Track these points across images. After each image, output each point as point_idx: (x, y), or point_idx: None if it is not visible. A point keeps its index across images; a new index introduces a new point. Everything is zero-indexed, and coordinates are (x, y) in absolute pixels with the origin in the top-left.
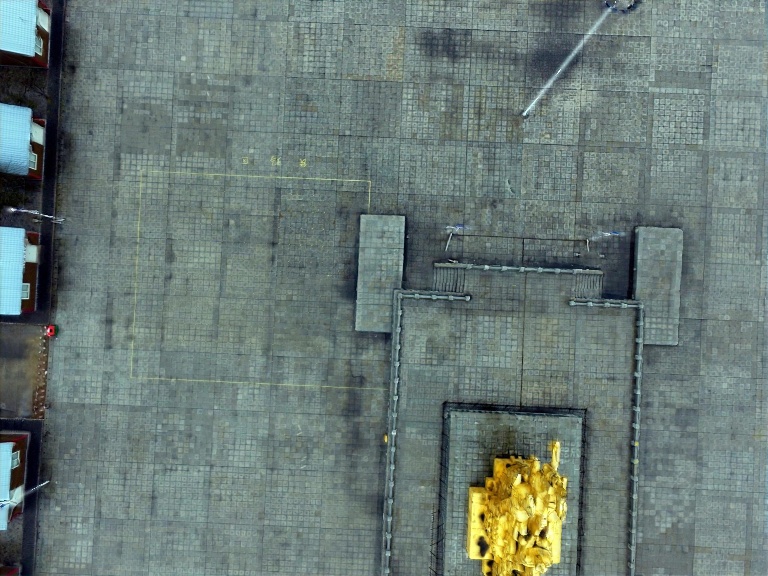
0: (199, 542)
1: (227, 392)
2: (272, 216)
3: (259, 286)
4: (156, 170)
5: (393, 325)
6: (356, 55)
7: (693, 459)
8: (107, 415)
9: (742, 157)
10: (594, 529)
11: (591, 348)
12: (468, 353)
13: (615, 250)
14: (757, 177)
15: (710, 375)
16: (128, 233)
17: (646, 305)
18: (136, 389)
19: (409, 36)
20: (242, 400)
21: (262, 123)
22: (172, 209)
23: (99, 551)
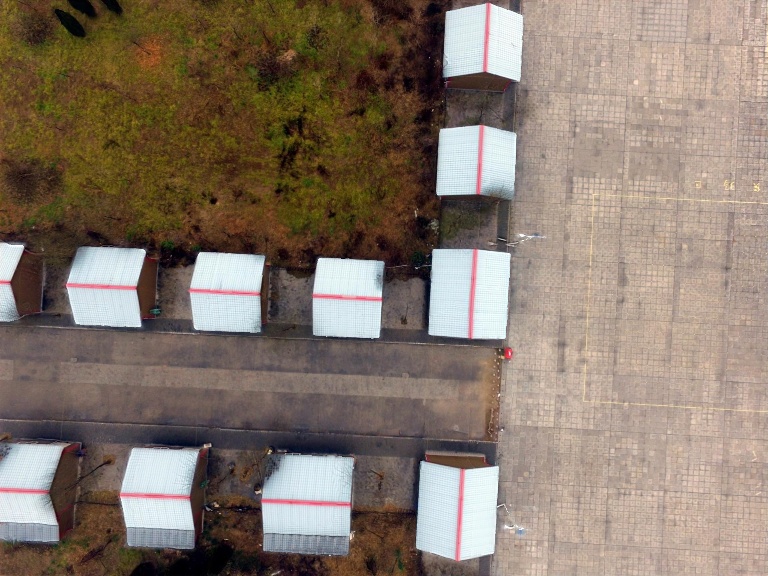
0: (654, 567)
1: (680, 417)
2: (725, 241)
3: (712, 311)
4: (608, 194)
5: None
6: None
7: None
8: (560, 438)
9: None
10: None
11: None
12: None
13: None
14: None
15: None
16: (581, 257)
17: None
18: (589, 413)
19: None
20: (696, 425)
21: (715, 147)
22: (624, 233)
23: (554, 575)
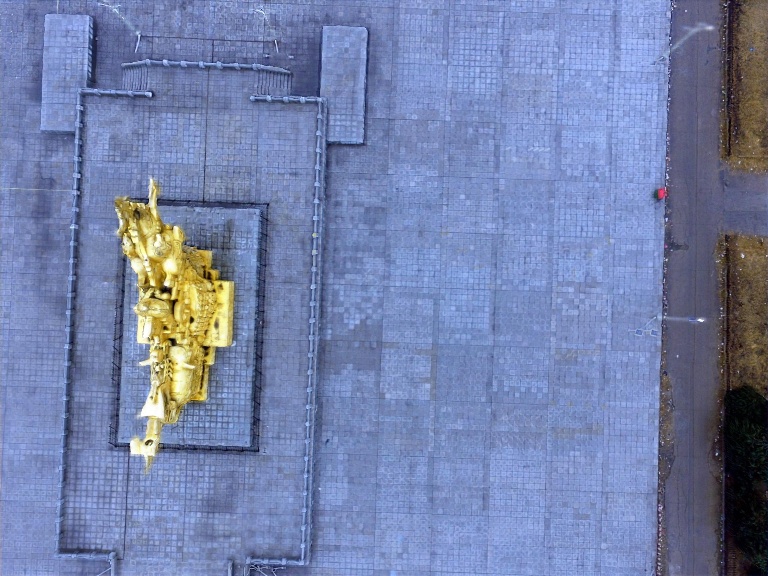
0: None
1: None
2: None
3: None
4: None
5: None
6: None
7: (381, 256)
8: None
9: None
10: (276, 322)
11: (273, 144)
12: (151, 150)
13: (304, 51)
14: None
15: (398, 174)
16: None
17: (330, 102)
18: None
19: None
20: None
21: None
22: None
23: None
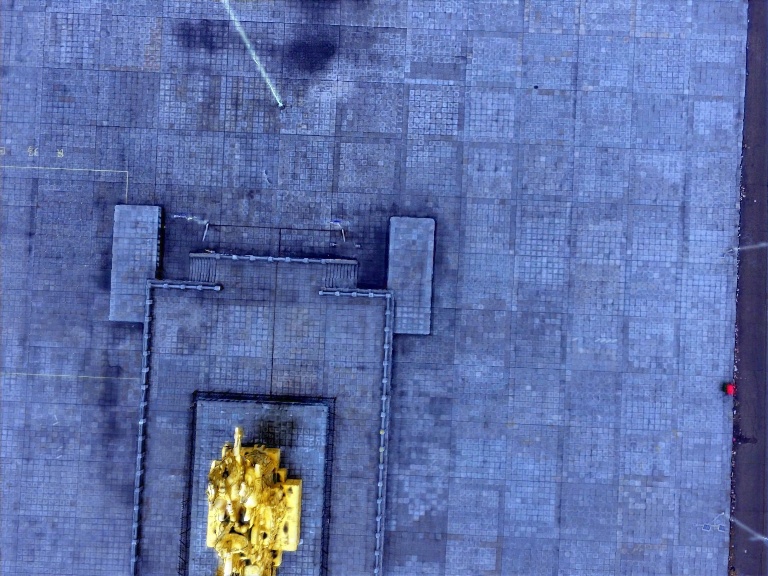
0: None
1: None
2: (29, 206)
3: (16, 276)
4: None
5: (145, 315)
6: (113, 46)
7: (447, 447)
8: None
9: (496, 148)
10: (343, 517)
11: (341, 337)
12: (219, 342)
13: (371, 240)
14: (511, 168)
15: (464, 364)
16: None
17: (397, 294)
18: None
19: (166, 27)
20: None
21: (19, 113)
22: None
23: None
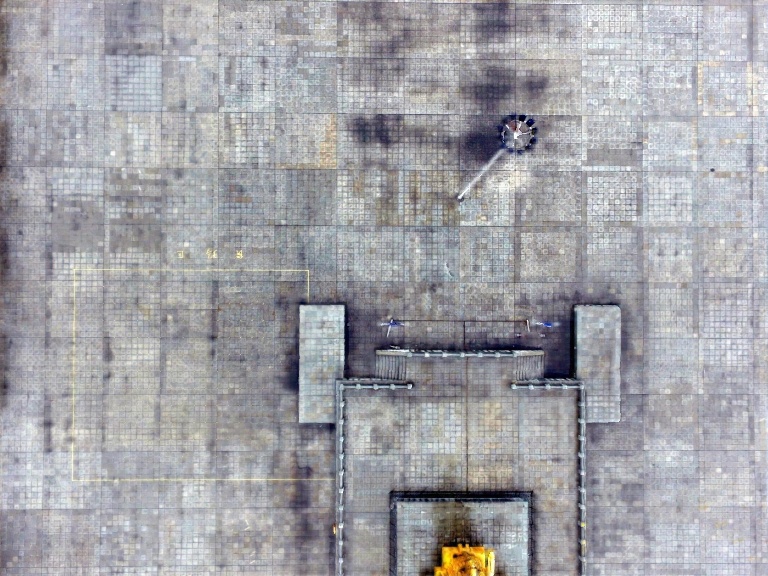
0: None
1: (172, 490)
2: (210, 310)
3: (200, 381)
4: (90, 268)
5: (336, 416)
6: (289, 144)
7: (641, 533)
8: (49, 520)
9: (676, 231)
10: None
11: (535, 430)
12: (413, 441)
13: (555, 329)
14: (691, 251)
15: (654, 449)
16: (63, 334)
17: (587, 384)
18: (78, 492)
19: (341, 123)
20: (187, 498)
21: (196, 216)
22: (108, 307)
23: None
